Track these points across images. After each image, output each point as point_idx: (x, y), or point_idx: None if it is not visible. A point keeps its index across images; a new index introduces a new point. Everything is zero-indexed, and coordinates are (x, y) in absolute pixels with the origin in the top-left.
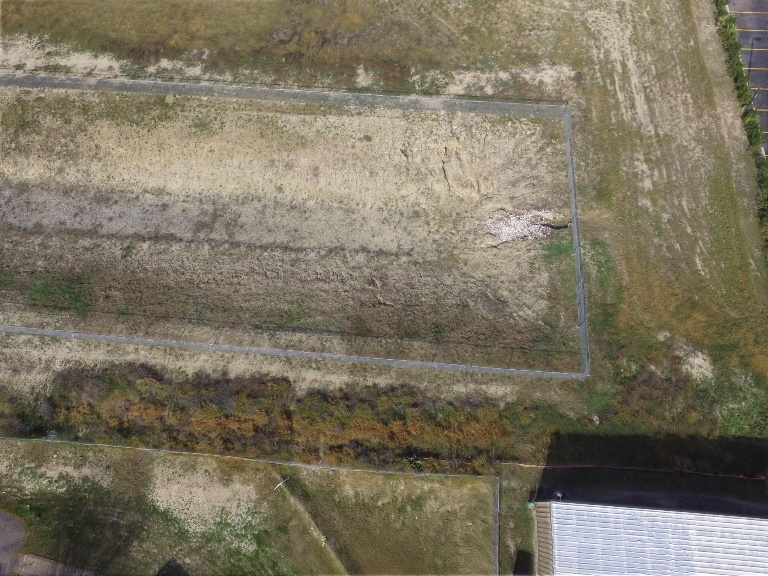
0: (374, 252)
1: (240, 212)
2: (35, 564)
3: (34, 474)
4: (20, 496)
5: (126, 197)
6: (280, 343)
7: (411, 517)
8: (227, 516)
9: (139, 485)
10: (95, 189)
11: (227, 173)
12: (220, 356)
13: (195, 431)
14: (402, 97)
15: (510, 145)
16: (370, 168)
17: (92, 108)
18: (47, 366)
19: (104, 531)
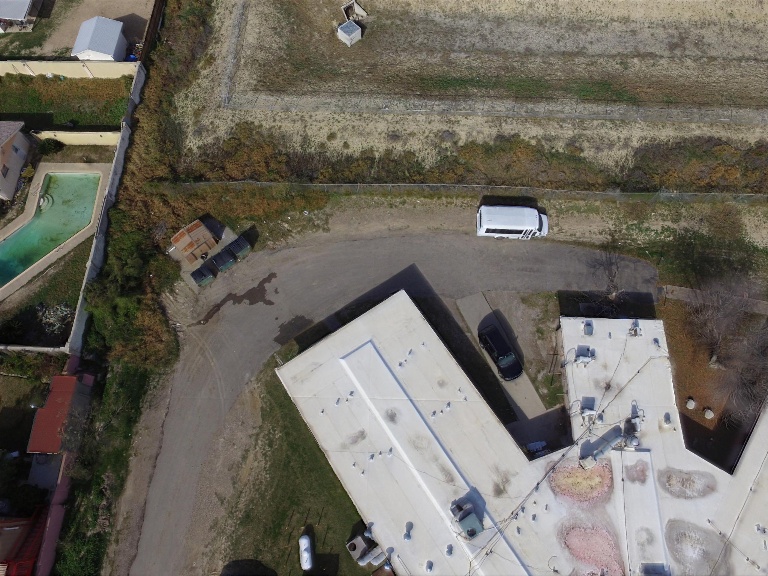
0: None
1: (702, 34)
2: (675, 292)
3: (639, 229)
4: (635, 245)
5: (596, 26)
6: None
7: None
8: None
9: (734, 231)
10: (567, 20)
11: (682, 3)
12: None
13: None
14: None
15: None
16: None
17: None
18: (625, 143)
19: (720, 266)
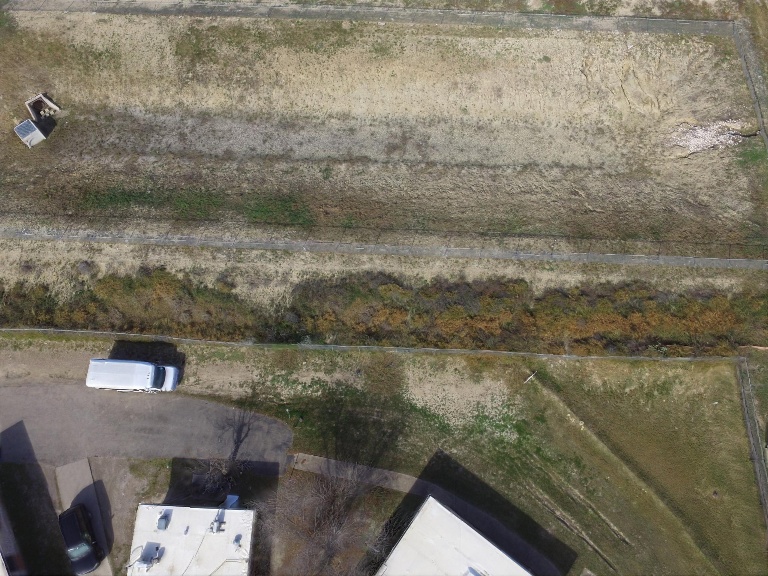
0: (568, 167)
1: (429, 134)
2: (307, 462)
3: (286, 381)
4: (276, 402)
5: (312, 123)
6: (510, 248)
7: (659, 400)
8: (483, 409)
9: (392, 385)
10: (280, 116)
11: (411, 97)
12: (454, 262)
13: (443, 332)
14: (575, 19)
15: (685, 63)
16: (552, 88)
17: (269, 36)
18: (284, 278)
19: (367, 429)
